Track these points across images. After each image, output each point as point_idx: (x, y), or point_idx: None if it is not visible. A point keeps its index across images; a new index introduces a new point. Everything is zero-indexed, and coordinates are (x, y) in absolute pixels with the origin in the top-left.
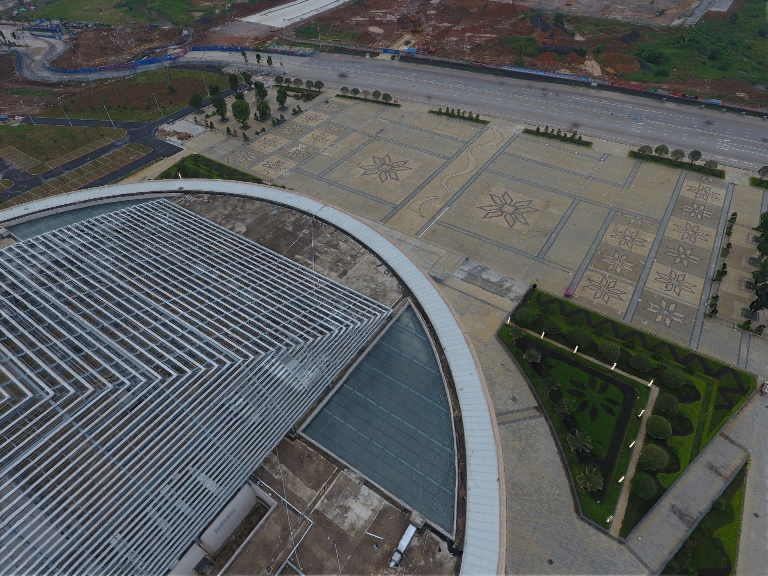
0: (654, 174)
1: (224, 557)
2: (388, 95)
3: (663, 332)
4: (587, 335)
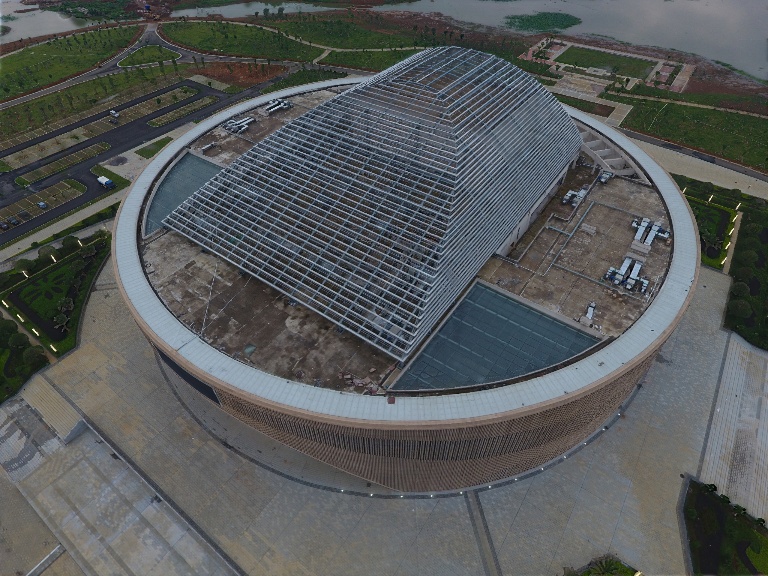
0: None
1: None
2: None
3: None
4: None
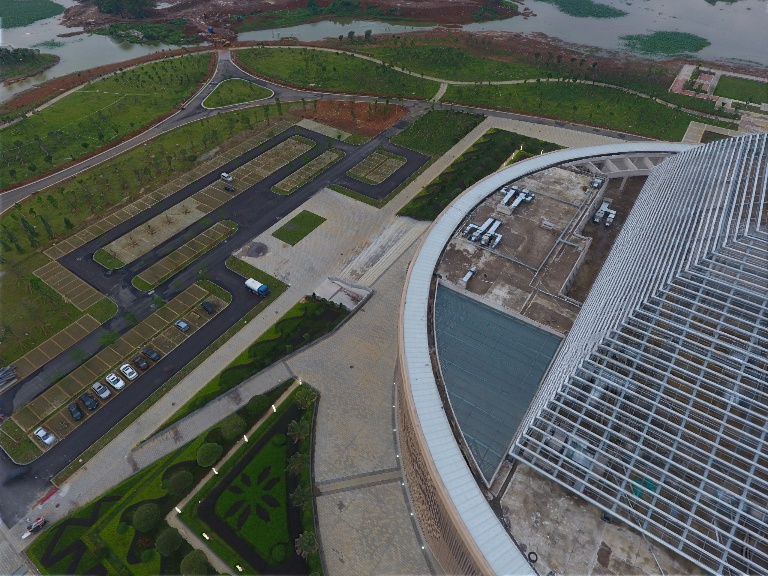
0: None
1: (581, 300)
2: None
3: None
4: None
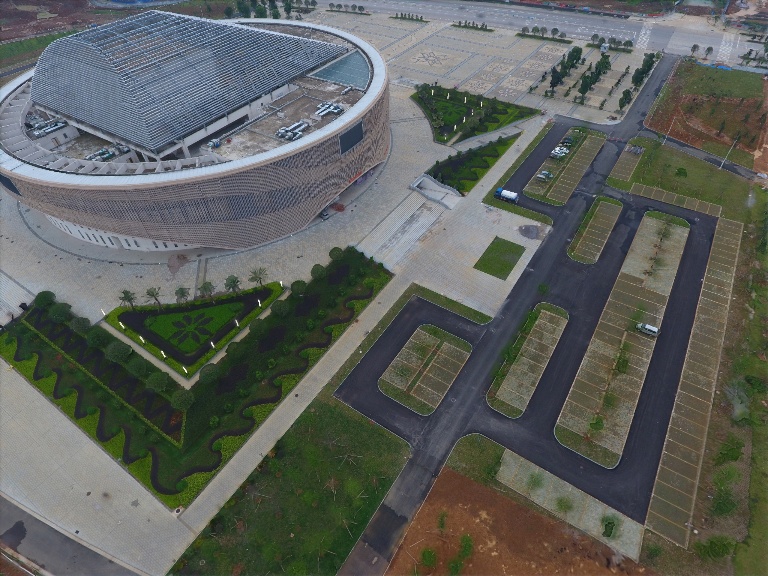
0: (528, 43)
1: None
2: (362, 7)
3: (502, 99)
4: (454, 89)
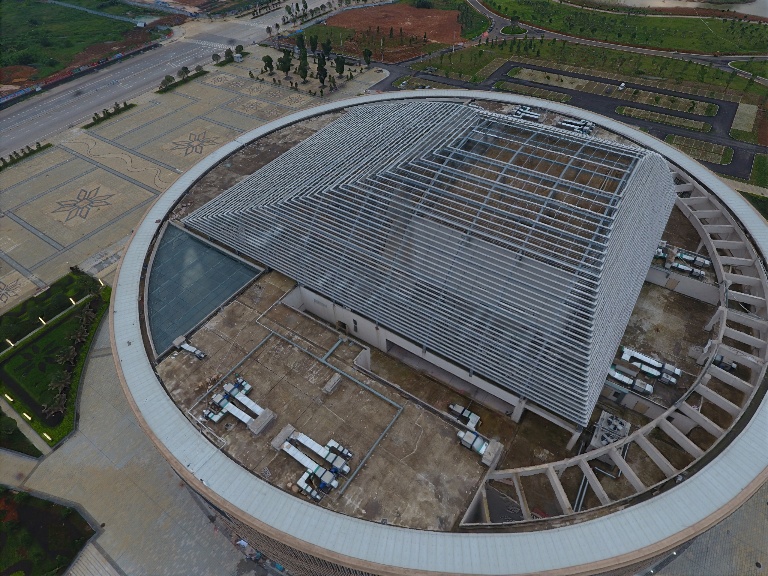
0: (190, 89)
1: None
2: None
3: None
4: None
